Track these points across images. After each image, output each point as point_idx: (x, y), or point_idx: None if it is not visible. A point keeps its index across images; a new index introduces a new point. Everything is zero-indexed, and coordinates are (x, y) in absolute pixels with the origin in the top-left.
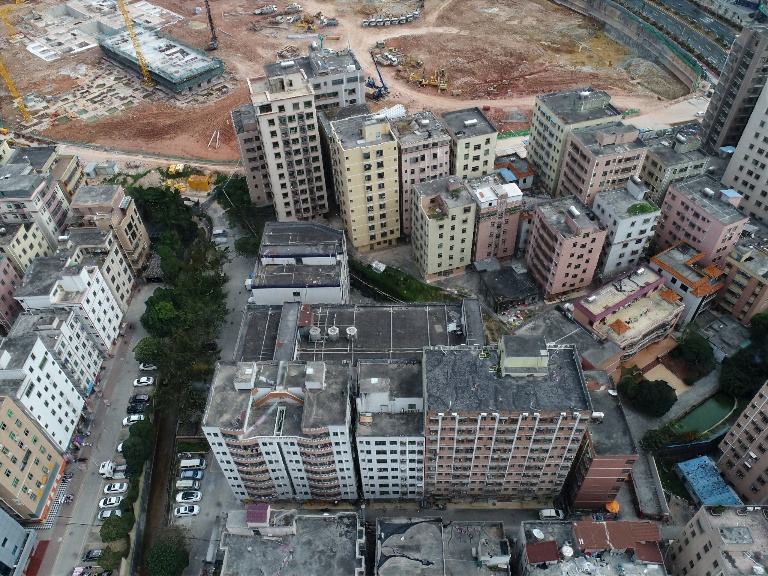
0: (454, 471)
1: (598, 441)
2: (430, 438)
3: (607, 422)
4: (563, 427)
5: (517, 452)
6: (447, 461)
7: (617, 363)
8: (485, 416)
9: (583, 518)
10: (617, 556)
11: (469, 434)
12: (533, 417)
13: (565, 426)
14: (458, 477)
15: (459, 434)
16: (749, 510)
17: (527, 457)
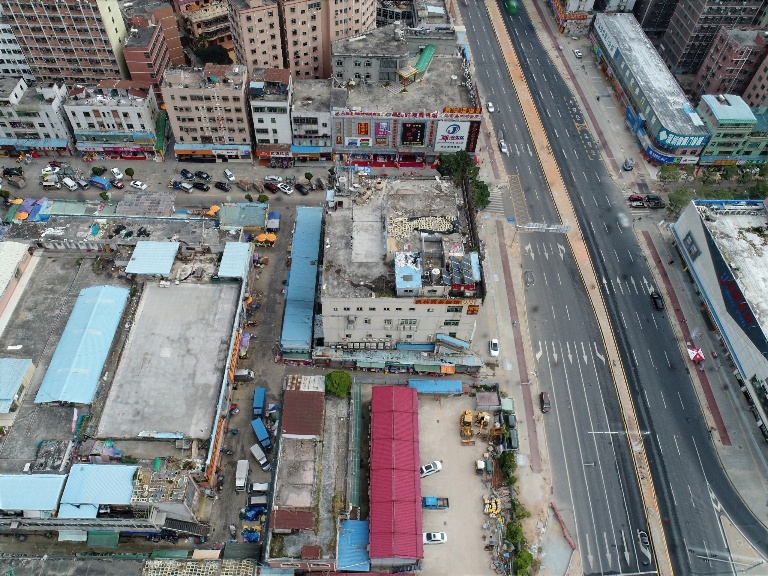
0: (47, 65)
1: (131, 44)
2: (13, 25)
3: (143, 38)
4: (88, 17)
5: (75, 44)
6: (37, 53)
7: (174, 19)
8: (35, 3)
9: (108, 79)
10: (123, 97)
11: (34, 21)
12: (64, 5)
13: (88, 16)
14: (53, 71)
15: (28, 22)
16: (195, 69)
17: (84, 50)
